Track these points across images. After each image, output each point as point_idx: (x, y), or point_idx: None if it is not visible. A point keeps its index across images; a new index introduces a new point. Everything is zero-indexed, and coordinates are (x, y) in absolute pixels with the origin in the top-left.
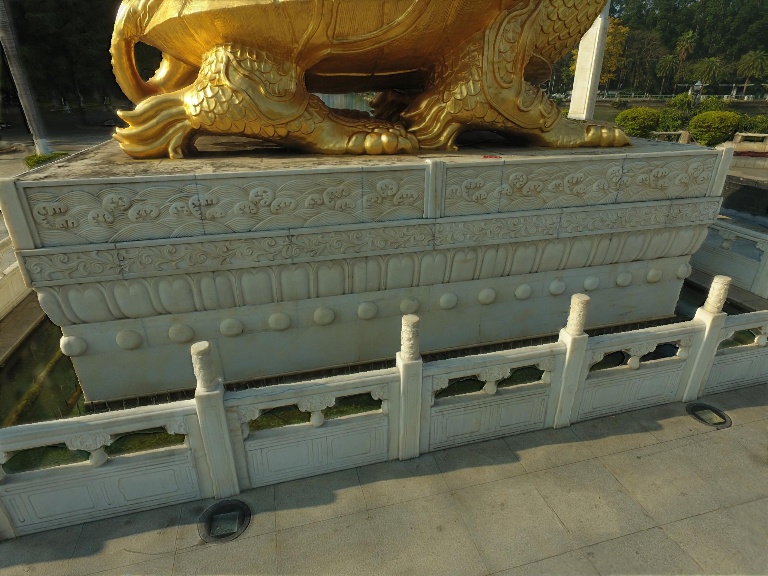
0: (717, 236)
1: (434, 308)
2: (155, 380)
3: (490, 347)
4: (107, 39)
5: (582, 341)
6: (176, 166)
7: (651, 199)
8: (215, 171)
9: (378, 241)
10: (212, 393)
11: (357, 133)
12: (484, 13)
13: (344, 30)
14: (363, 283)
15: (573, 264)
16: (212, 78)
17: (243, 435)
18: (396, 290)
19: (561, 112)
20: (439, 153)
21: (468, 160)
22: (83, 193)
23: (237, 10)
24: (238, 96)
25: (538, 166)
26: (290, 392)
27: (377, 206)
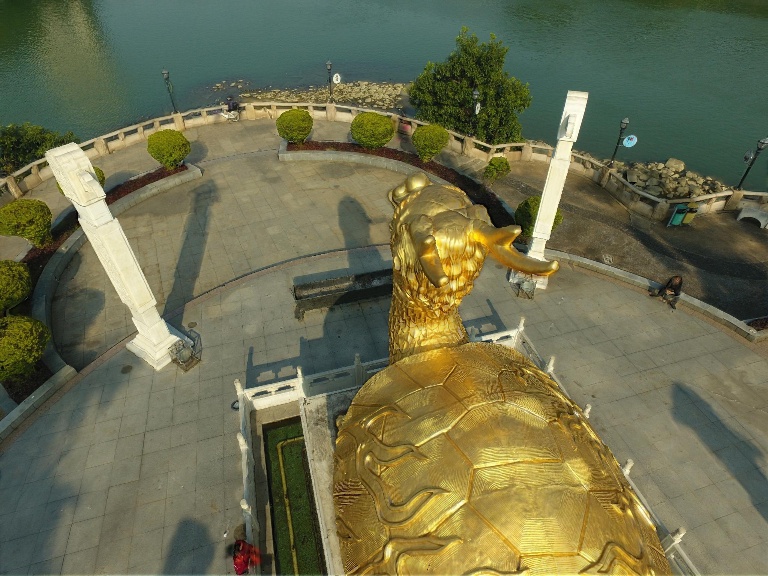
0: (372, 330)
1: None
2: None
3: None
4: None
5: None
6: None
7: None
8: None
9: None
10: None
11: None
12: None
13: None
14: None
15: None
16: None
17: None
18: None
19: None
20: None
21: None
22: None
23: None
24: None
25: None
26: None
27: None
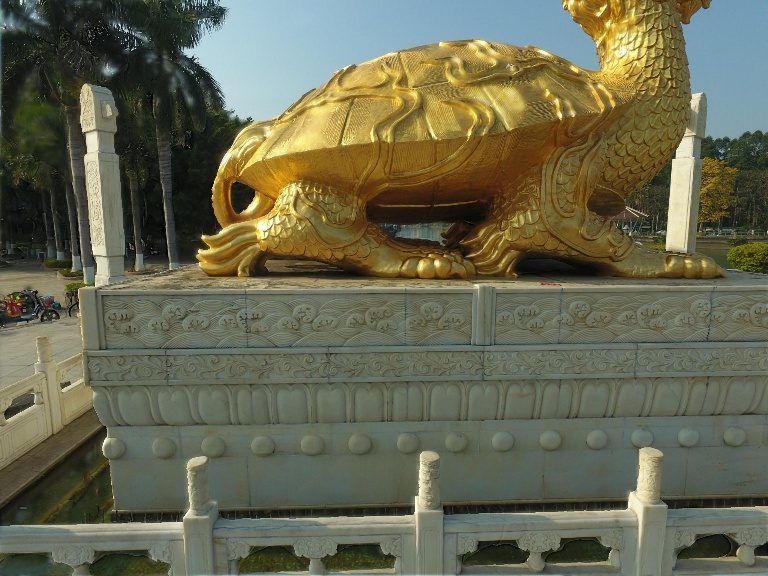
0: None
1: (486, 448)
2: (182, 495)
3: (556, 506)
4: (245, 186)
5: (659, 513)
6: (237, 283)
7: (756, 339)
8: (266, 288)
9: (420, 366)
10: (201, 517)
11: (411, 258)
12: (539, 150)
13: (400, 167)
14: (403, 411)
15: (660, 411)
16: (282, 208)
17: (230, 575)
18: (441, 422)
19: (662, 247)
20: (495, 279)
21: (522, 286)
22: (148, 302)
23: (307, 153)
24: (301, 223)
25: (603, 295)
26: (286, 529)
27: (421, 329)
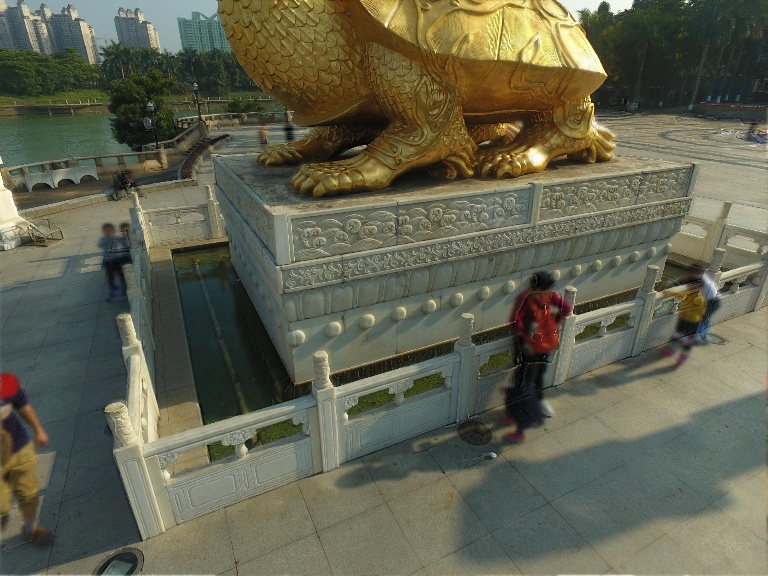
0: None
1: None
2: None
3: None
4: None
5: None
6: None
7: None
8: None
9: None
10: None
11: None
12: None
13: None
14: None
15: None
16: None
17: None
18: None
19: None
20: None
21: None
22: None
23: None
24: None
25: None
26: None
27: None
